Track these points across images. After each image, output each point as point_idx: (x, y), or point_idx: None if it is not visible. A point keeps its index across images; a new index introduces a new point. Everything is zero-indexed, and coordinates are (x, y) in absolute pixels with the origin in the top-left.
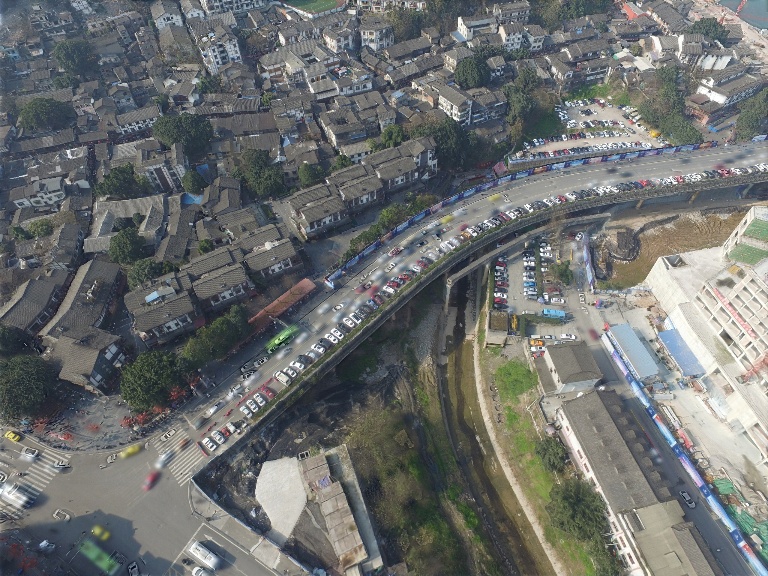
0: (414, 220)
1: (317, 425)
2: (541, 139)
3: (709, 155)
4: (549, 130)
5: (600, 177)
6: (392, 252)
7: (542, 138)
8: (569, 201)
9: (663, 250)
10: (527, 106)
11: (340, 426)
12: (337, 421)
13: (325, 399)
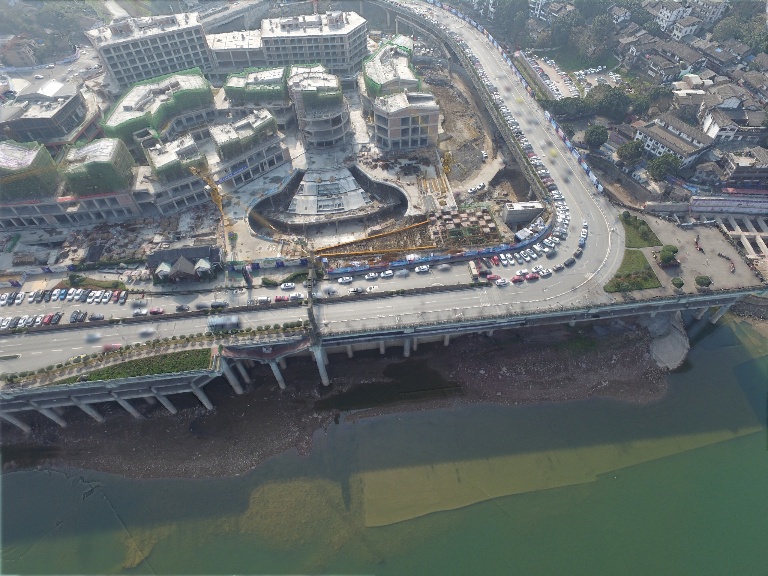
0: (436, 4)
1: (331, 0)
2: (554, 62)
3: (521, 95)
4: (569, 66)
5: (484, 53)
6: (414, 2)
7: (558, 65)
8: (458, 43)
9: (434, 93)
10: (557, 24)
11: (331, 7)
12: (334, 7)
13: (343, 4)
